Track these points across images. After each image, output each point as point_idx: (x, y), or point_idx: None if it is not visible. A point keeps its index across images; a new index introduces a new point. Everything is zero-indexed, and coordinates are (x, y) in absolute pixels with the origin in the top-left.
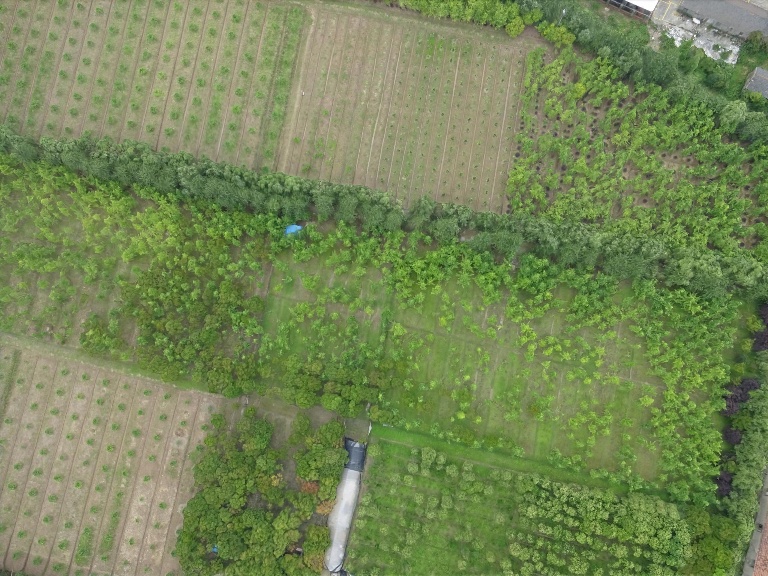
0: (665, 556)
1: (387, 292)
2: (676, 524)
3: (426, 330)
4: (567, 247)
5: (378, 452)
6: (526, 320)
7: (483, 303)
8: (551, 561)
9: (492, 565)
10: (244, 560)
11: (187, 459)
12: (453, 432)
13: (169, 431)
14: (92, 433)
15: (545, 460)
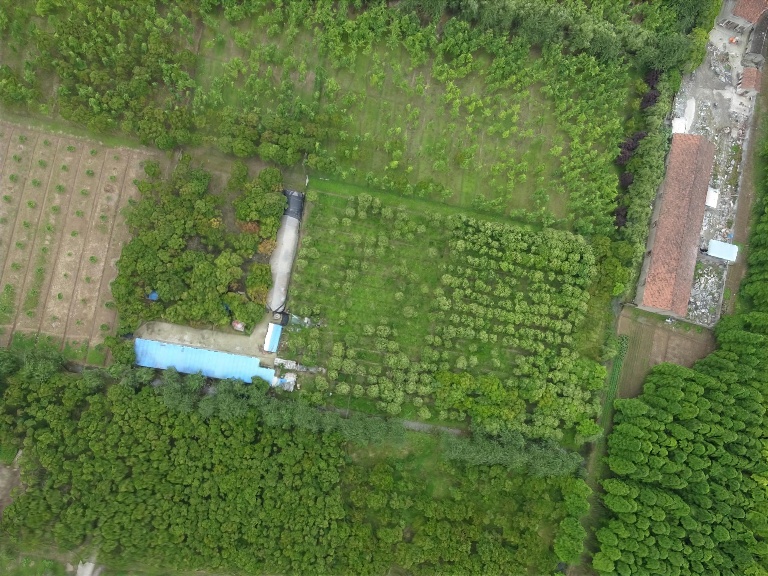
0: (575, 278)
1: (320, 50)
2: (583, 248)
3: (358, 92)
4: (486, 8)
5: (317, 197)
6: (451, 79)
7: (411, 65)
8: (479, 286)
9: (426, 300)
10: (185, 300)
11: (118, 215)
12: (387, 176)
13: (97, 188)
14: (9, 191)
15: (470, 207)
